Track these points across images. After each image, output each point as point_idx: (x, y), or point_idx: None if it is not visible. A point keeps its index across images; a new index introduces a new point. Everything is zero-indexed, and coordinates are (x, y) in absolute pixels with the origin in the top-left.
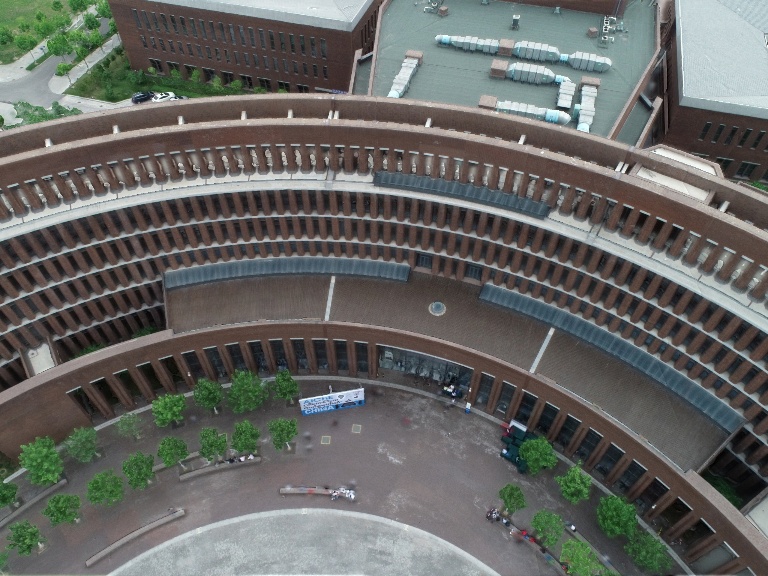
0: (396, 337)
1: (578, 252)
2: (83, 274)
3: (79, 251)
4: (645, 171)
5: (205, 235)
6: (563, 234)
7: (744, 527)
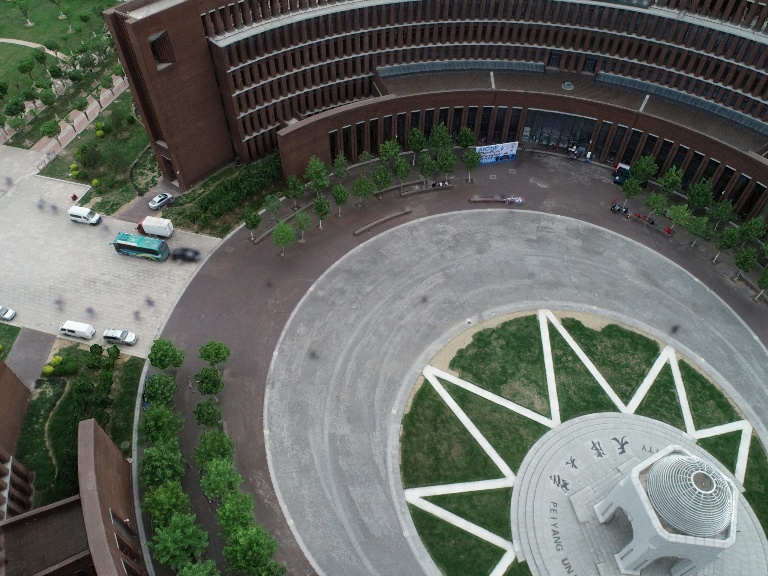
0: (544, 99)
1: (671, 29)
2: (330, 61)
3: (334, 40)
4: None
5: (410, 37)
6: (662, 15)
7: None
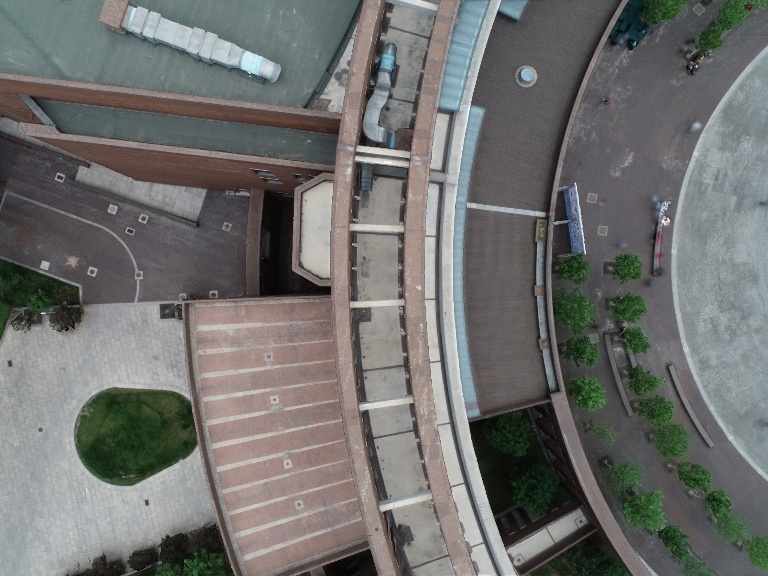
0: None
1: None
2: None
3: None
4: None
5: None
6: None
7: None
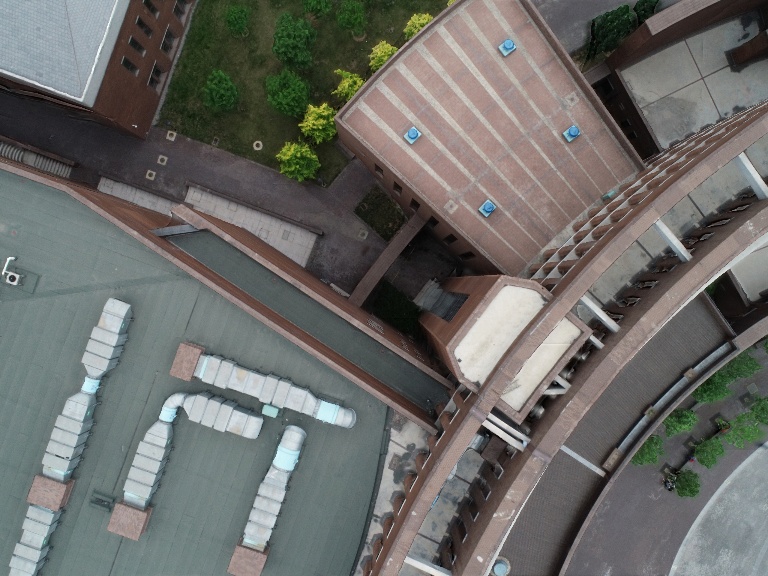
0: None
1: None
2: None
3: None
4: (508, 394)
5: None
6: None
7: None
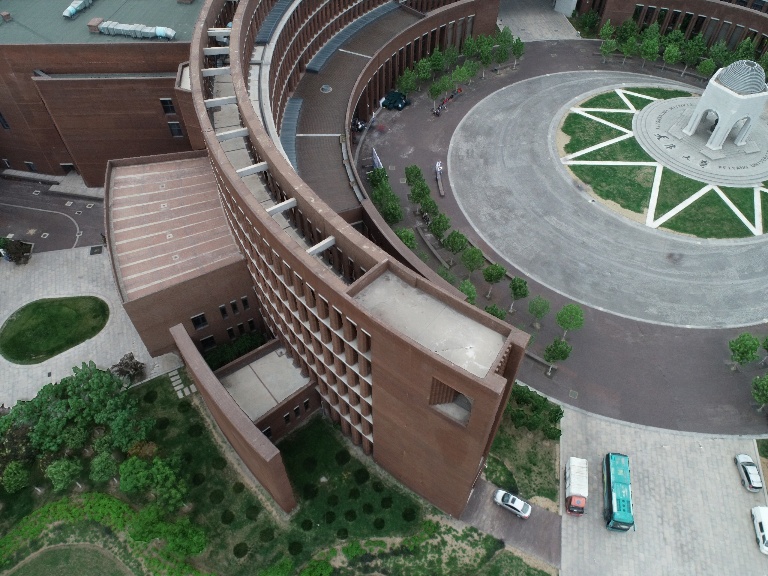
0: None
1: None
2: None
3: None
4: None
5: None
6: None
7: (449, 7)
